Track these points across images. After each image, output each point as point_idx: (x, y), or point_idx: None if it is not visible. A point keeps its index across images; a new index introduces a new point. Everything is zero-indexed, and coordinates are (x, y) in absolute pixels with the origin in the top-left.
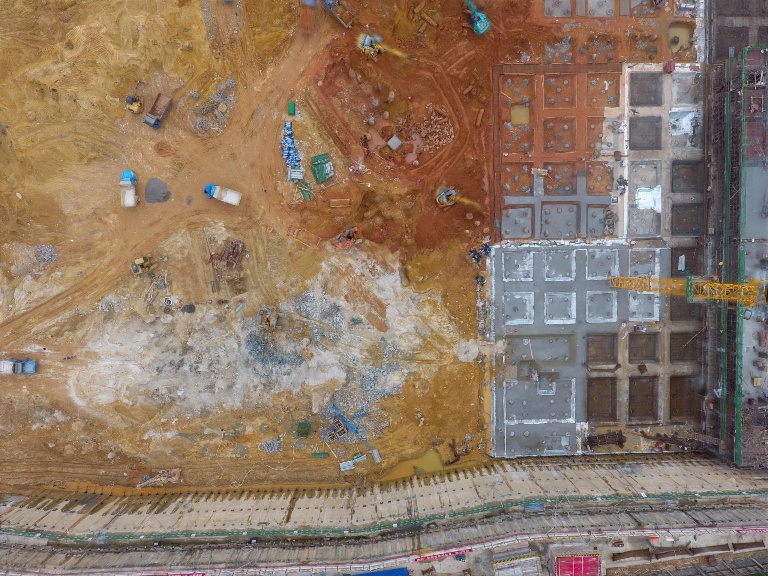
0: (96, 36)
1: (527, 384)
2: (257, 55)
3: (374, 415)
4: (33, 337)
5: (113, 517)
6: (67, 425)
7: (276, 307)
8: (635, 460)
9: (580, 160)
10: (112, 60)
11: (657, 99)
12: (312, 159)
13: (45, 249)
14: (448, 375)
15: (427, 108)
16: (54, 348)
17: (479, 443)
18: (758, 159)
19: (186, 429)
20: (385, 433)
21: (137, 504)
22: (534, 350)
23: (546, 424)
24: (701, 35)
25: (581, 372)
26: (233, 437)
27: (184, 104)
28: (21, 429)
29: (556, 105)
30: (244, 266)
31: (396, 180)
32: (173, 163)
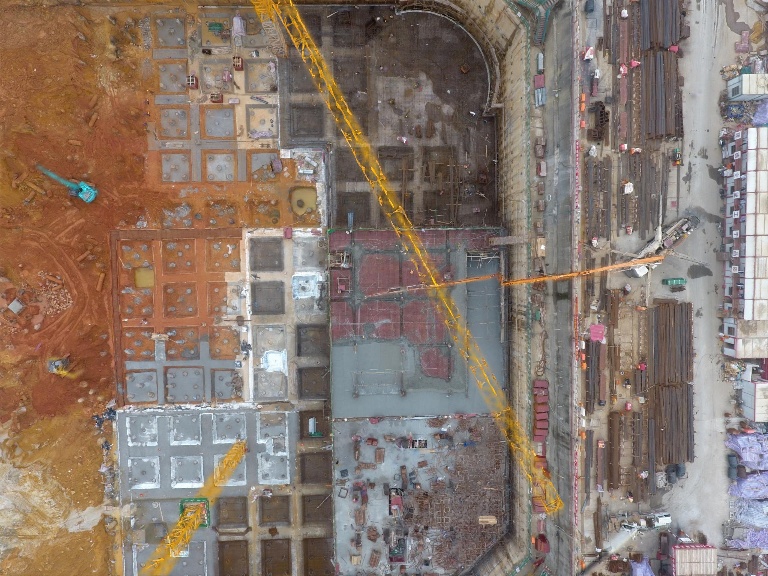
0: None
1: (158, 547)
2: None
3: None
4: None
5: None
6: None
7: None
8: None
9: (201, 325)
10: None
11: (281, 263)
12: None
13: None
14: (50, 551)
15: (39, 275)
16: None
17: None
18: (348, 339)
19: None
20: None
21: None
22: (165, 513)
23: None
24: (324, 199)
25: (211, 535)
26: None
27: None
28: None
29: (178, 269)
30: None
31: (8, 348)
32: None
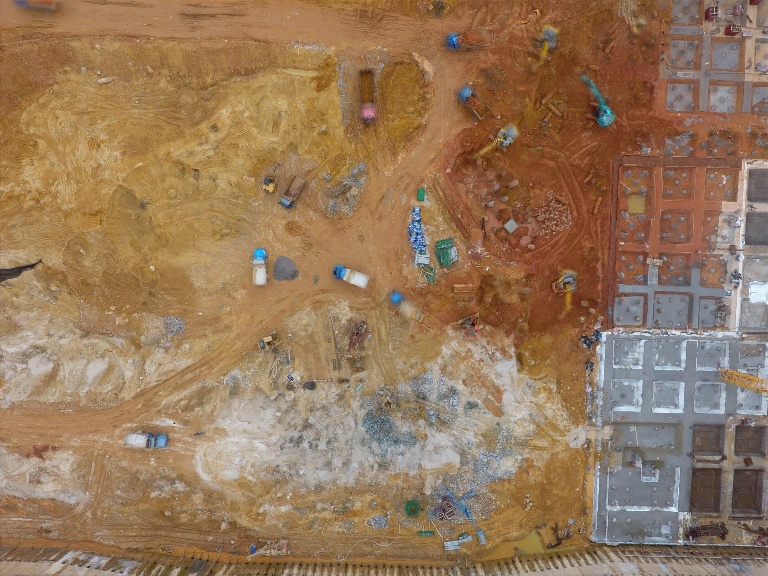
0: (241, 120)
1: (631, 470)
2: (389, 141)
3: (483, 497)
4: (164, 411)
5: None
6: (186, 495)
7: (394, 387)
8: (739, 554)
9: (696, 252)
10: (255, 144)
11: None
12: (437, 243)
13: (174, 321)
14: (560, 463)
15: (547, 195)
16: (183, 423)
17: (581, 527)
18: None
19: (299, 504)
20: (492, 515)
21: (246, 575)
22: (639, 437)
23: (649, 512)
24: None
25: (686, 462)
26: (342, 512)
27: (316, 185)
28: (140, 497)
29: (673, 196)
30: (366, 346)
31: (514, 264)
32: (303, 242)
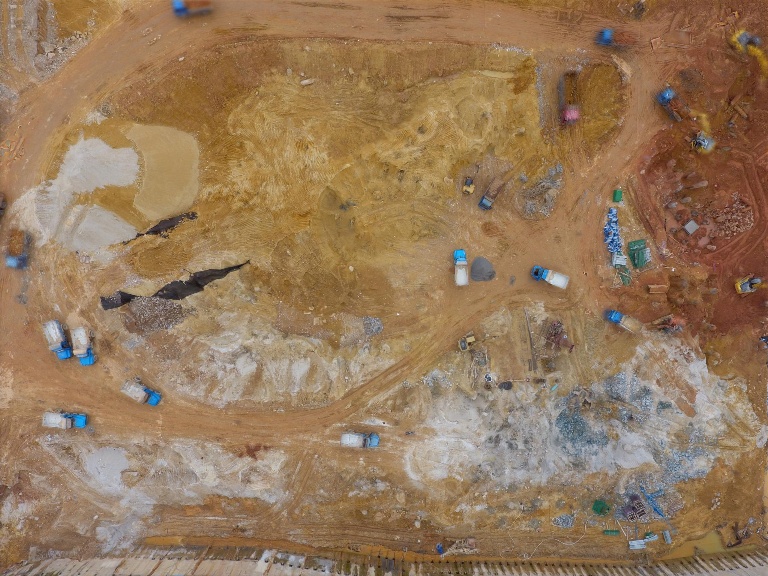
0: (448, 122)
1: None
2: (584, 142)
3: (671, 497)
4: (373, 411)
5: None
6: (385, 494)
7: (587, 387)
8: None
9: None
10: (461, 145)
11: None
12: (629, 244)
13: (373, 321)
14: (751, 462)
15: (732, 196)
16: (393, 422)
17: (760, 527)
18: None
19: (494, 503)
20: (678, 515)
21: (439, 574)
22: None
23: None
24: None
25: None
26: (531, 511)
27: (512, 186)
28: (340, 496)
29: None
30: (561, 346)
31: (698, 265)
32: (500, 243)
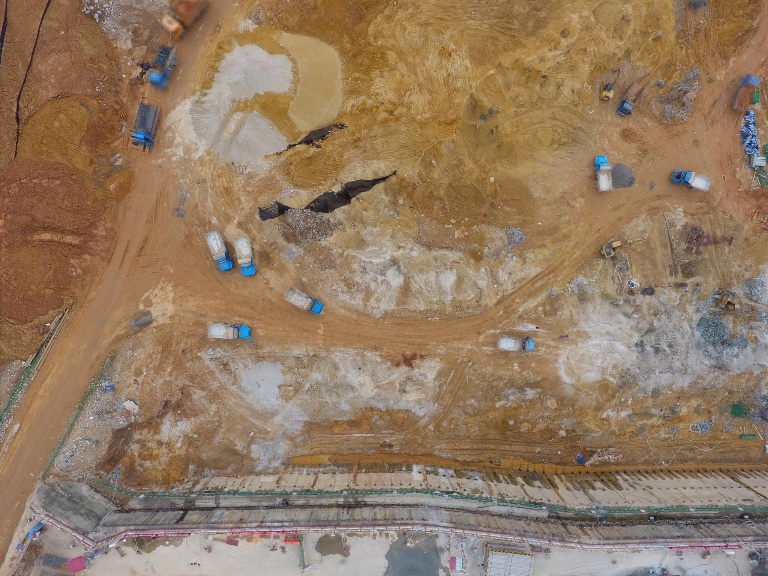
0: (590, 24)
1: None
2: (719, 45)
3: None
4: (527, 316)
5: (584, 492)
6: (533, 403)
7: None
8: None
9: None
10: (603, 48)
11: None
12: (765, 147)
13: (516, 232)
14: None
15: None
16: (546, 327)
17: None
18: None
19: (638, 409)
20: None
21: (584, 481)
22: None
23: None
24: None
25: None
26: (671, 418)
27: (648, 92)
28: (488, 406)
29: None
30: (701, 251)
31: None
32: (638, 149)
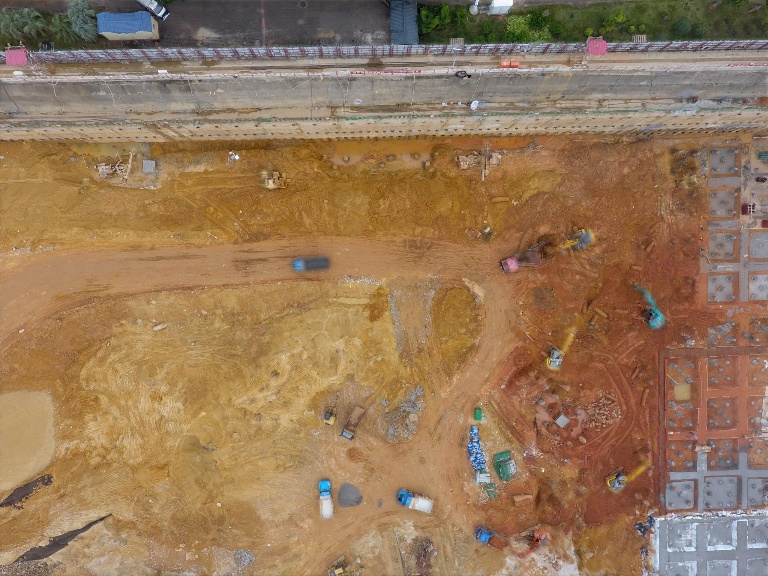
0: (300, 364)
1: None
2: (443, 362)
3: None
4: None
5: None
6: None
7: None
8: None
9: (742, 438)
10: (315, 386)
11: None
12: (495, 457)
13: (244, 555)
14: None
15: (597, 394)
16: None
17: None
18: None
19: None
20: None
21: None
22: None
23: None
24: None
25: None
26: None
27: (374, 411)
28: None
29: (718, 384)
30: (432, 563)
31: (568, 463)
32: (365, 469)
